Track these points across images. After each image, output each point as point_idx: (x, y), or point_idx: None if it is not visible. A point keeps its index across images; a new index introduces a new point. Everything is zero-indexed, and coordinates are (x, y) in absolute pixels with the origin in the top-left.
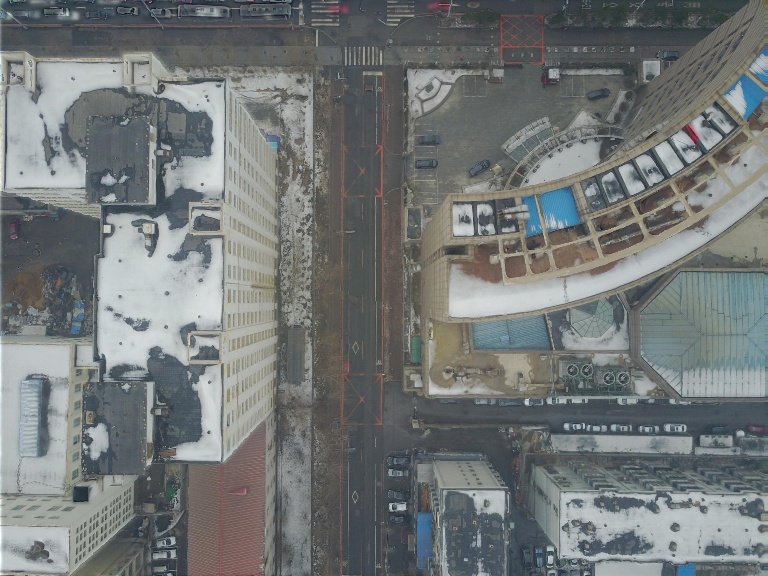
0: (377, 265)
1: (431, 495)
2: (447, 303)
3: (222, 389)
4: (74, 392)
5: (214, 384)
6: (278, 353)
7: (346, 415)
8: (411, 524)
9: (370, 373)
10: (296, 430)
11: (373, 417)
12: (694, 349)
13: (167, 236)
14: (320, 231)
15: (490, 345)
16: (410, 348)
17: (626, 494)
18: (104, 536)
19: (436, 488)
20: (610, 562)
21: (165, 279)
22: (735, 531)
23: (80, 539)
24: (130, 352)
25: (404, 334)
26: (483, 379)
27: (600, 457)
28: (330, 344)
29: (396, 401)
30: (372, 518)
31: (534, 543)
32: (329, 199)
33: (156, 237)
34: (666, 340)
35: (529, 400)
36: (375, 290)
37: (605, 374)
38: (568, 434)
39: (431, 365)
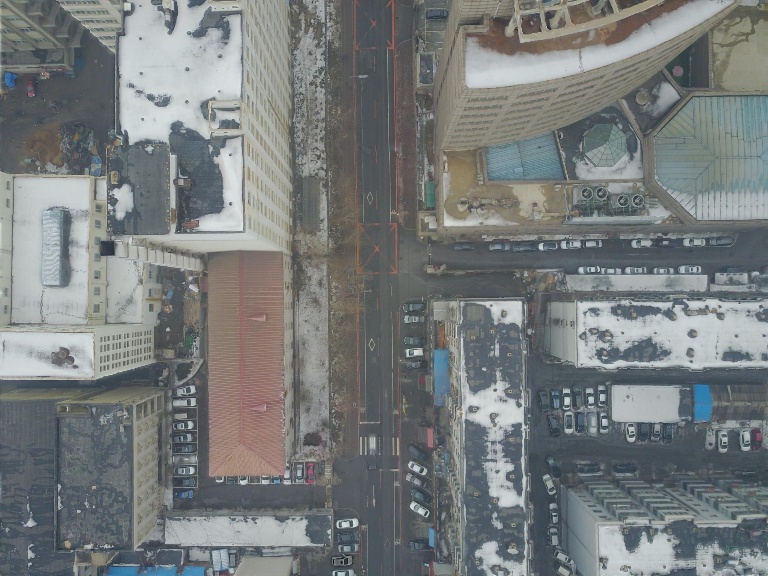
0: (390, 116)
1: (448, 324)
2: (463, 72)
3: (243, 160)
4: (94, 227)
5: (235, 157)
6: (293, 204)
7: (361, 264)
8: (428, 370)
9: (385, 222)
10: (312, 280)
11: (388, 266)
12: (708, 172)
13: (186, 13)
14: (333, 84)
15: (504, 177)
16: (424, 196)
17: (643, 302)
18: (126, 362)
19: (453, 316)
20: (627, 400)
21: (185, 55)
22: (752, 337)
23: (104, 350)
24: (152, 127)
25: (418, 181)
26: (498, 210)
27: (615, 293)
28: (345, 185)
29: (411, 250)
30: (389, 365)
31: (550, 386)
32: (341, 52)
33: (175, 15)
34: (680, 164)
35: (543, 245)
36: (388, 141)
37: (619, 196)
38: (583, 275)
39: (446, 197)
